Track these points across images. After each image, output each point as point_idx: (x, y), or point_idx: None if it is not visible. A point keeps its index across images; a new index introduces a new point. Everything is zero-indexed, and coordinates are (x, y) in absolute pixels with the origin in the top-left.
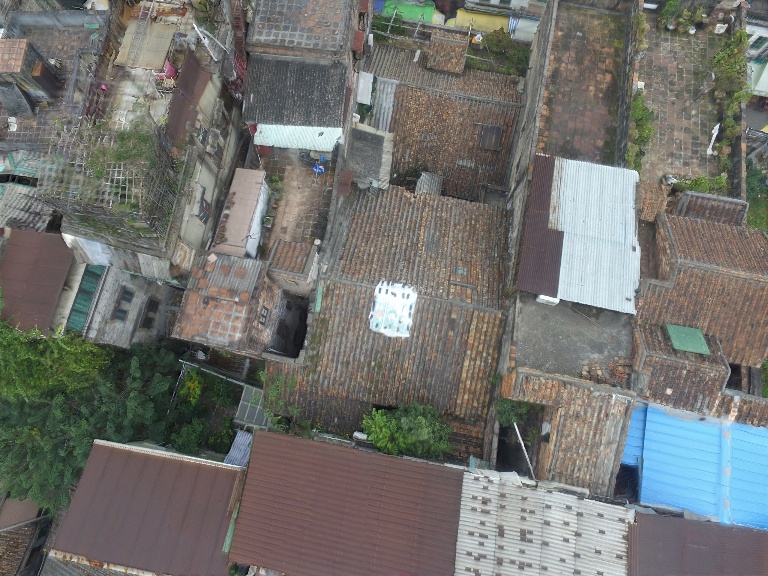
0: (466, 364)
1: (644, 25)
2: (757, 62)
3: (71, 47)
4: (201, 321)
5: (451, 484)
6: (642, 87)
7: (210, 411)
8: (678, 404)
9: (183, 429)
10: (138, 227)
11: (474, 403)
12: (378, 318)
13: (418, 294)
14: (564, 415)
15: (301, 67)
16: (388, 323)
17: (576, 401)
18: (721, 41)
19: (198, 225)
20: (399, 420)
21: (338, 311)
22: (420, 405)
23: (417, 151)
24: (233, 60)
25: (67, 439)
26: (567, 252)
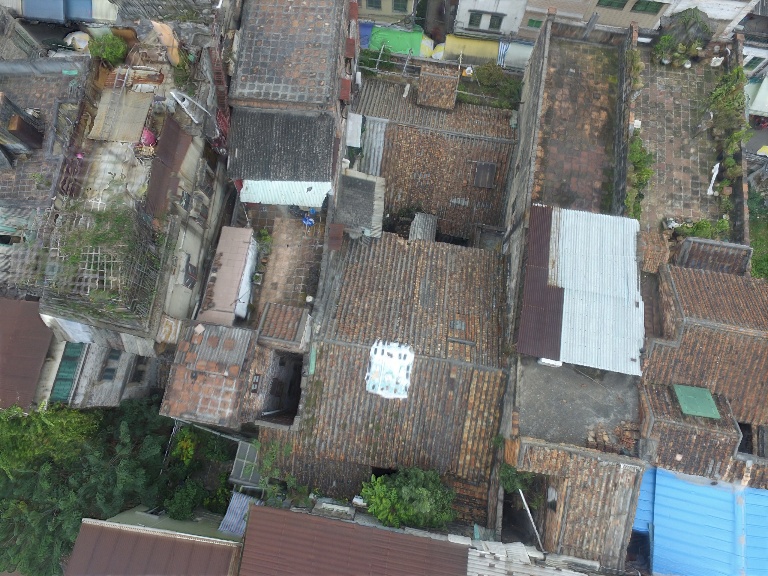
0: (467, 424)
1: (639, 63)
2: (752, 82)
3: (49, 95)
4: (189, 397)
5: (456, 561)
6: (639, 126)
7: (205, 466)
8: (688, 469)
9: (176, 495)
10: (119, 311)
11: (477, 463)
12: (374, 379)
13: (415, 354)
14: (571, 486)
15: (287, 119)
16: (385, 384)
17: (583, 471)
18: (717, 74)
19: (184, 292)
20: (399, 488)
21: (333, 373)
22: (421, 471)
23: (410, 190)
24: (215, 118)
25: (55, 512)
26: (568, 310)
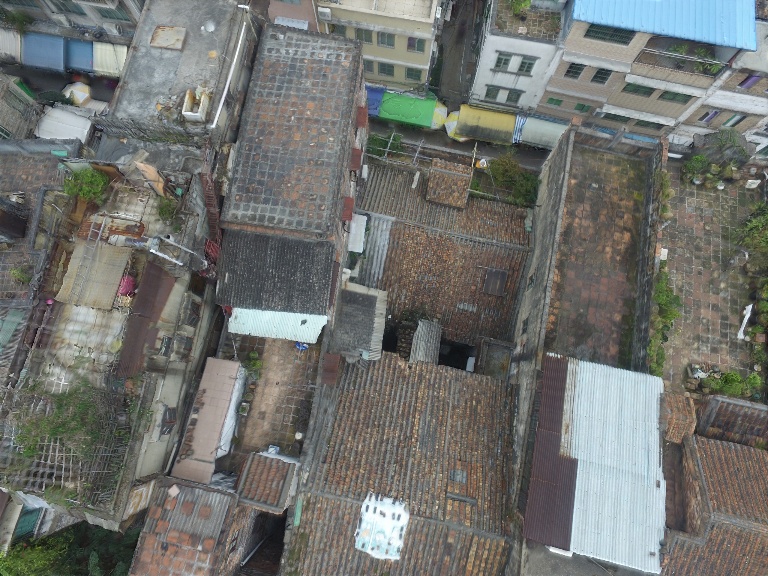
0: None
1: (669, 190)
2: None
3: (36, 177)
4: (158, 572)
5: None
6: (665, 255)
7: None
8: None
9: None
10: None
11: None
12: (365, 537)
13: (410, 514)
14: None
15: (283, 243)
16: (376, 543)
17: None
18: (752, 197)
19: (160, 441)
20: None
21: (320, 526)
22: None
23: (414, 292)
24: (203, 250)
25: None
26: (581, 487)
